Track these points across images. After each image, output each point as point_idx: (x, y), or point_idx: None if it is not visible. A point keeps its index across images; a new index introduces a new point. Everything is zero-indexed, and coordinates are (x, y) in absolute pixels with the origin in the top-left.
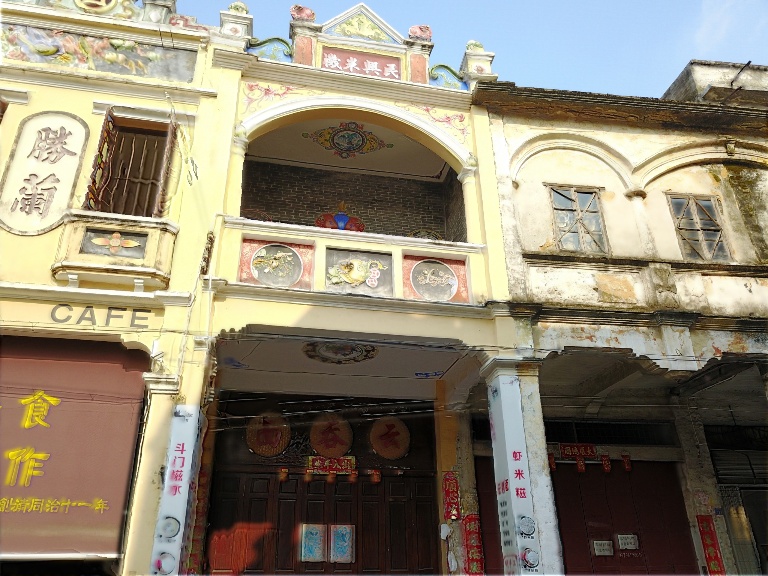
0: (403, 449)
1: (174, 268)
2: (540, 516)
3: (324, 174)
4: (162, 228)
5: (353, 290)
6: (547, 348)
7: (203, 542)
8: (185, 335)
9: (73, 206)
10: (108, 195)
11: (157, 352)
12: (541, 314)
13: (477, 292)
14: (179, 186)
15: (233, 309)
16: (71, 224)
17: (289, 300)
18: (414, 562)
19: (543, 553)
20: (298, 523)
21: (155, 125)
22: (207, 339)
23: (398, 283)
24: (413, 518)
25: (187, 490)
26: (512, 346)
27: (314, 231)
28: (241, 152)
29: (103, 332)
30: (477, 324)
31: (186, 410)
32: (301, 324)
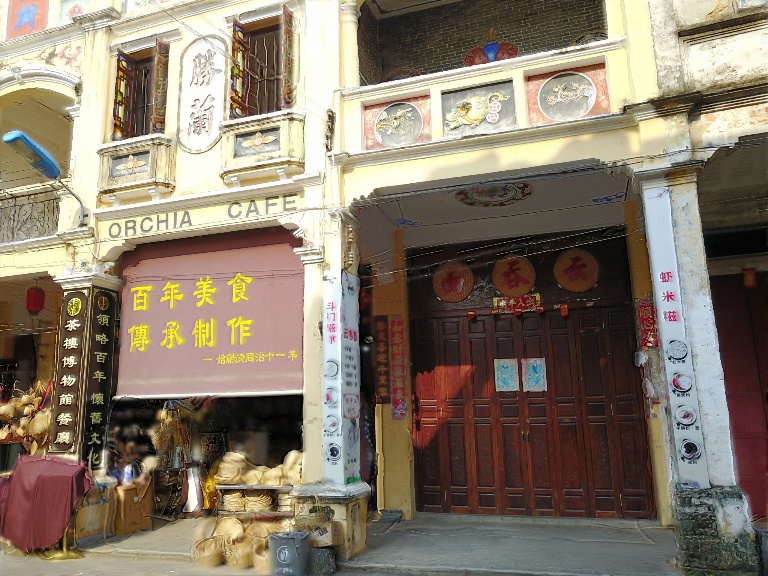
0: (591, 280)
1: (306, 152)
2: (695, 339)
3: (468, 4)
4: (290, 118)
5: (473, 131)
6: (713, 145)
7: (406, 378)
8: (322, 210)
9: (227, 118)
10: (254, 99)
11: (297, 230)
12: (703, 104)
13: (618, 97)
14: (301, 73)
15: (360, 178)
16: (225, 135)
17: (408, 157)
18: (611, 389)
19: (698, 377)
20: (489, 358)
21: (277, 19)
22: (337, 210)
23: (520, 111)
24: (607, 347)
25: (340, 339)
26: (660, 152)
27: (427, 79)
28: (352, 18)
29: (265, 220)
30: (618, 135)
31: (331, 274)
32: (422, 178)
